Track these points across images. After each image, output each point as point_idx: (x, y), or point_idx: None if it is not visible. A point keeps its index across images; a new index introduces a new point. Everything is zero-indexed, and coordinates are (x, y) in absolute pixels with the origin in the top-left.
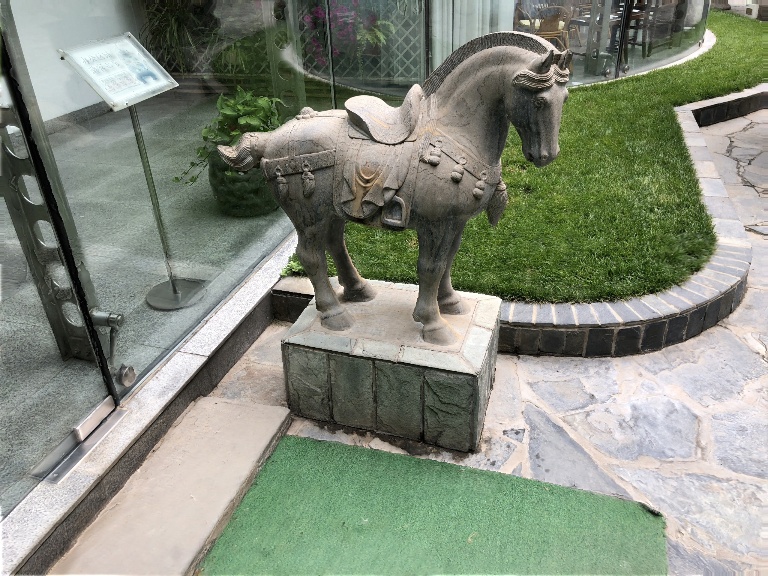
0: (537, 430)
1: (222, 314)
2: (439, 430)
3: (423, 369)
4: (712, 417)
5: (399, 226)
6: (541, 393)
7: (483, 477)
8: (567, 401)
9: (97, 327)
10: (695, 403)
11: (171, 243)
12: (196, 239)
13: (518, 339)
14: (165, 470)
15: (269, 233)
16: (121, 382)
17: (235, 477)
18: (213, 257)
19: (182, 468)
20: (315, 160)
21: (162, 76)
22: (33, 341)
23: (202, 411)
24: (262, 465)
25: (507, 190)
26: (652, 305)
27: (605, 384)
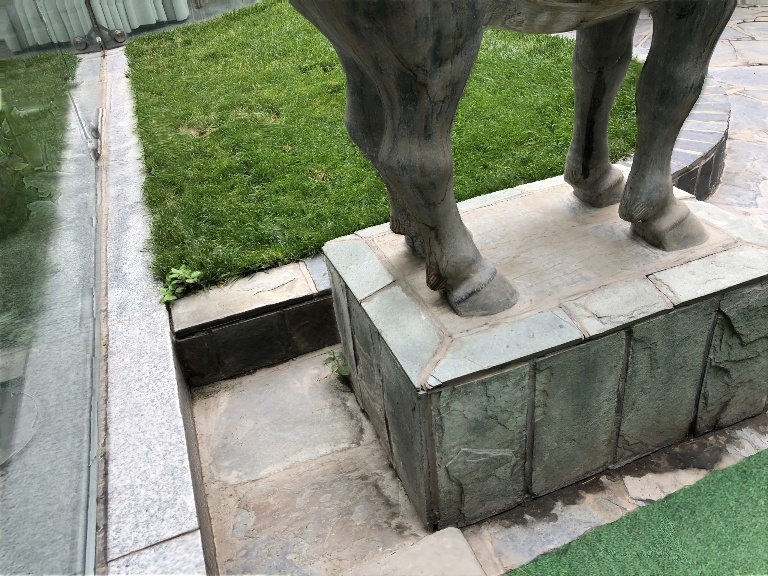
0: None
1: (124, 424)
2: (724, 400)
3: (719, 297)
4: None
5: None
6: None
7: None
8: None
9: None
10: None
11: None
12: None
13: None
14: None
15: (55, 254)
16: None
17: None
18: None
19: None
20: None
21: None
22: None
23: None
24: None
25: None
26: (697, 128)
27: None
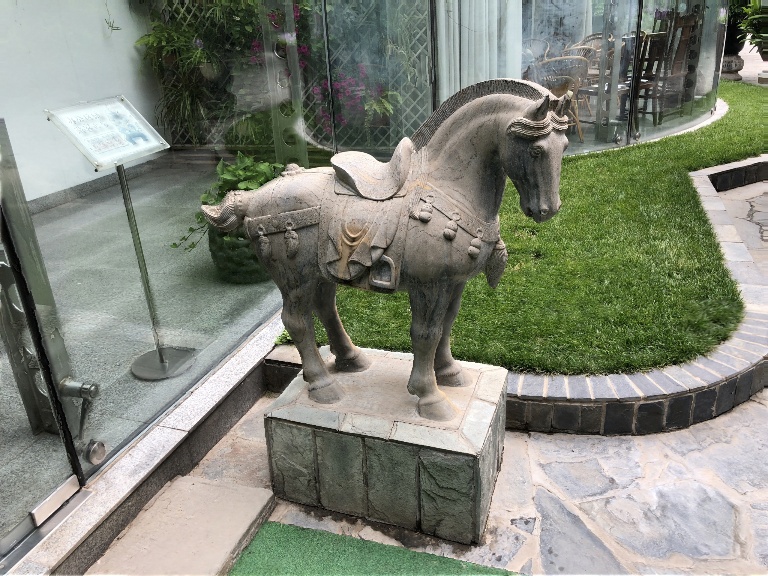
0: (549, 519)
1: (209, 385)
2: (437, 518)
3: (418, 448)
4: (750, 506)
5: (388, 288)
6: (554, 476)
7: (487, 575)
8: (584, 485)
9: (69, 398)
10: (730, 489)
11: (166, 310)
12: (192, 306)
13: (528, 414)
14: (128, 562)
15: (268, 300)
16: (88, 459)
17: (204, 571)
18: (207, 325)
19: (147, 559)
20: (299, 218)
21: (153, 138)
22: (6, 413)
23: (177, 493)
24: (237, 557)
25: (518, 256)
26: (676, 377)
27: (626, 466)
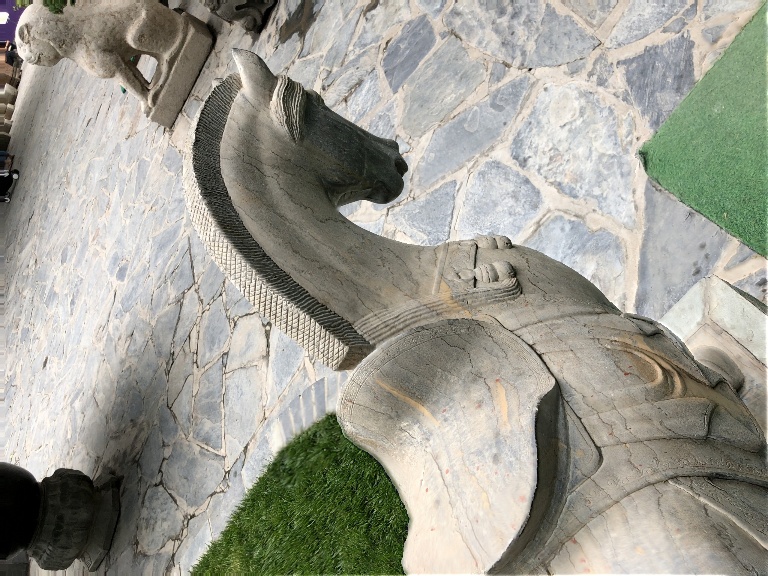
0: None
1: None
2: None
3: None
4: None
5: None
6: None
7: None
8: None
9: None
10: None
11: None
12: None
13: None
14: None
15: None
16: None
17: None
18: None
19: None
20: (761, 525)
21: None
22: None
23: None
24: None
25: None
26: None
27: None
